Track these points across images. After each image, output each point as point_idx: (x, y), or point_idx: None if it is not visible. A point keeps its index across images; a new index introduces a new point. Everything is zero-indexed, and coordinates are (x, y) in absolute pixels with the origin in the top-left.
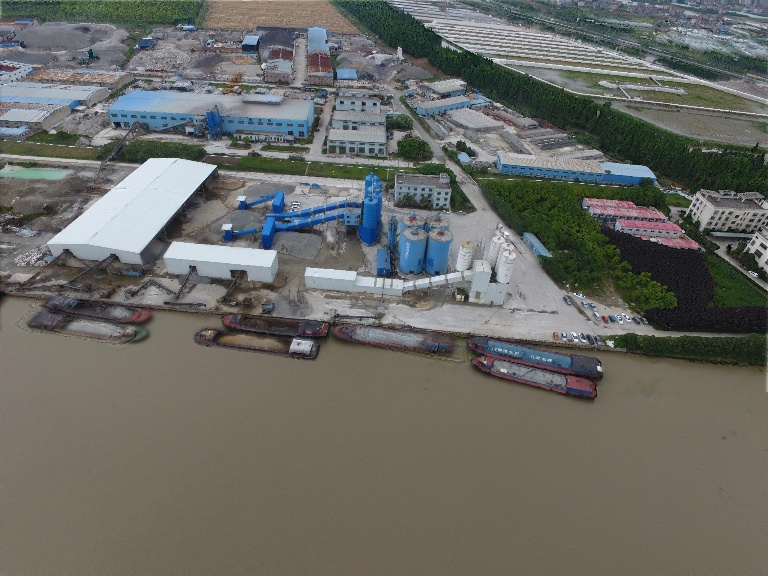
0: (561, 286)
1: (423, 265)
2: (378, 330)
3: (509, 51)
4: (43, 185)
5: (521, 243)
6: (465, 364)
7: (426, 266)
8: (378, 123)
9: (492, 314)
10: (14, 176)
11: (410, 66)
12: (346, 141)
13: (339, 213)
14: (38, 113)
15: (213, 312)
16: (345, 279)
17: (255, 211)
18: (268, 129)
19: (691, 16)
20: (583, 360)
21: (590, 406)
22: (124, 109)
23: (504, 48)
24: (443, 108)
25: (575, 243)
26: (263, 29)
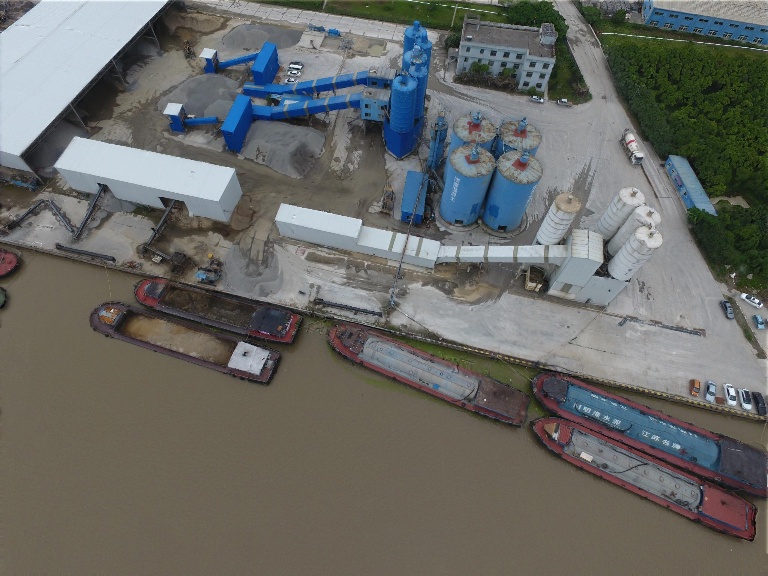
0: (720, 275)
1: (480, 210)
2: (380, 342)
3: None
4: None
5: (660, 174)
6: (519, 430)
7: (485, 213)
8: None
9: (585, 324)
10: None
11: None
12: None
13: (353, 97)
14: None
15: (127, 270)
16: (340, 233)
17: (231, 76)
18: None
19: None
20: (742, 457)
21: (733, 546)
22: None
23: None
24: None
25: (763, 187)
26: None
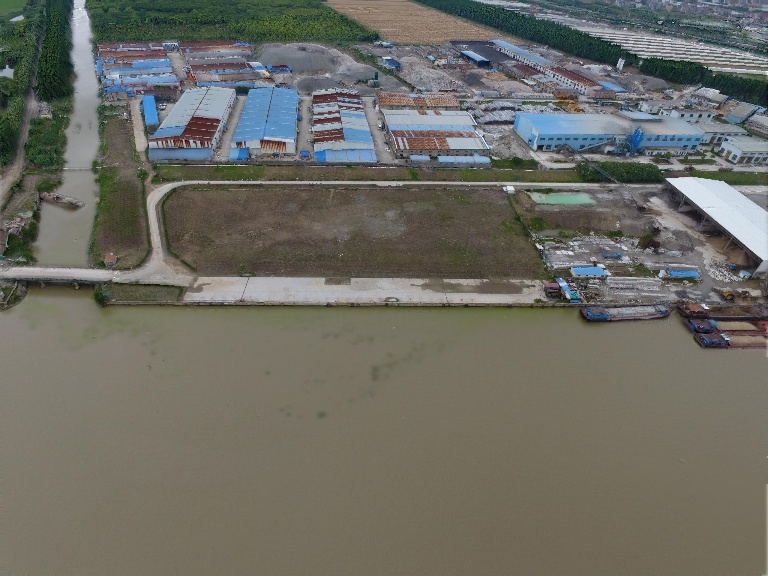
0: None
1: None
2: None
3: (669, 56)
4: (606, 209)
5: None
6: None
7: None
8: (742, 133)
9: None
10: (554, 202)
11: (646, 76)
12: (757, 152)
13: None
14: (474, 140)
15: None
16: None
17: None
18: (668, 144)
19: (737, 15)
20: None
21: None
22: (552, 133)
23: (663, 54)
24: (746, 116)
25: None
26: (457, 43)
